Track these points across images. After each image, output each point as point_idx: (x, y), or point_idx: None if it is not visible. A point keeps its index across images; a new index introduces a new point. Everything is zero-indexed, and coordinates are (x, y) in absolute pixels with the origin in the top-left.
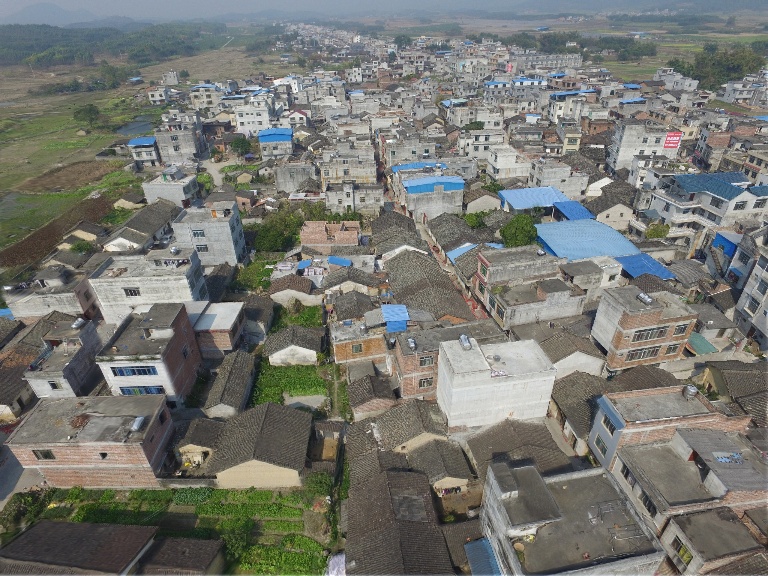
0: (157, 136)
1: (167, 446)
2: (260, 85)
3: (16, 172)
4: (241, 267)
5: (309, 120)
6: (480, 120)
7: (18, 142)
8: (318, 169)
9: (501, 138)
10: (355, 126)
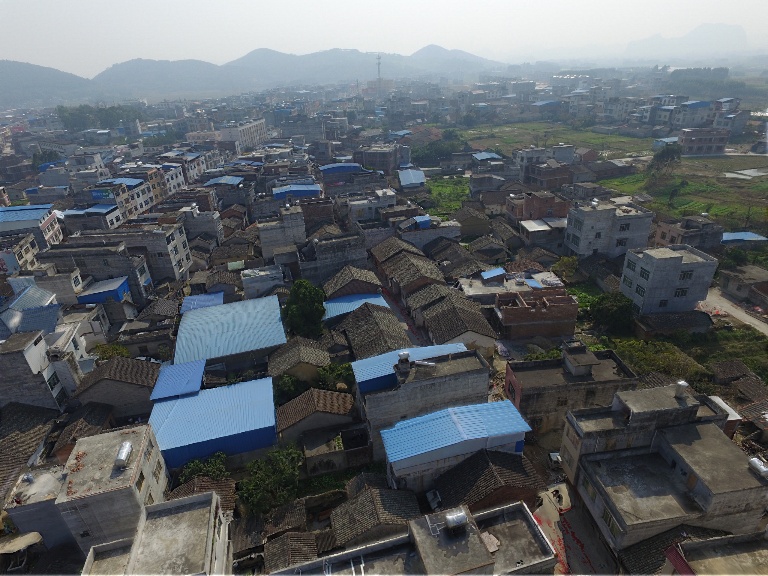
0: None
1: (509, 218)
2: None
3: None
4: None
5: None
6: None
7: None
8: None
9: None
10: None
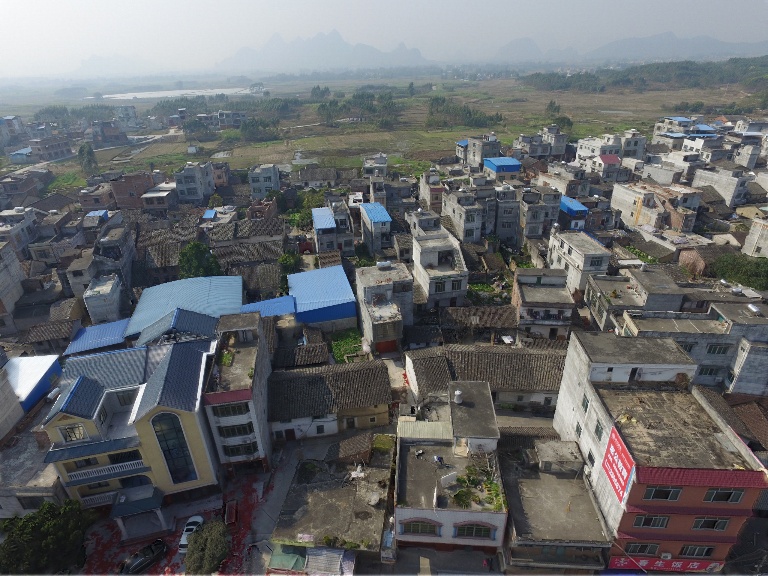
0: (469, 141)
1: None
2: None
3: (442, 146)
4: (216, 194)
5: (631, 173)
6: None
7: (510, 133)
8: (415, 192)
9: (582, 262)
10: (554, 180)
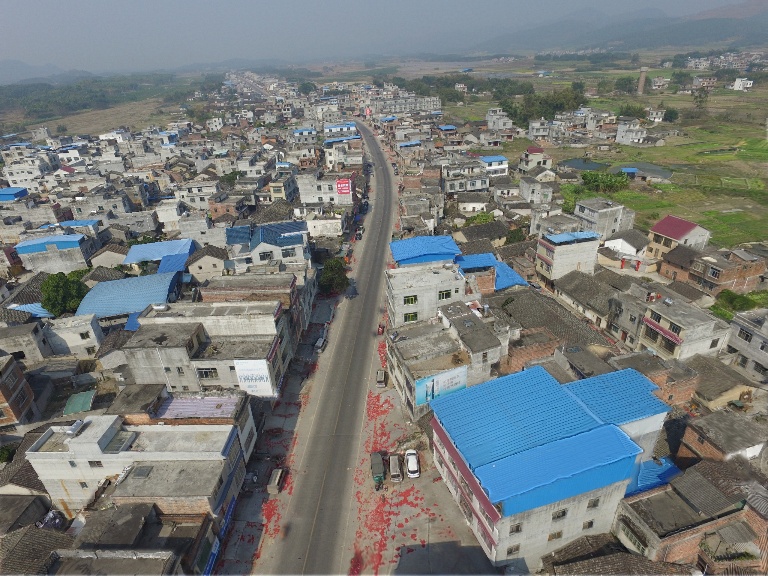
0: None
1: None
2: (91, 140)
3: None
4: None
5: None
6: (240, 170)
7: None
8: None
9: (214, 189)
10: (90, 182)
